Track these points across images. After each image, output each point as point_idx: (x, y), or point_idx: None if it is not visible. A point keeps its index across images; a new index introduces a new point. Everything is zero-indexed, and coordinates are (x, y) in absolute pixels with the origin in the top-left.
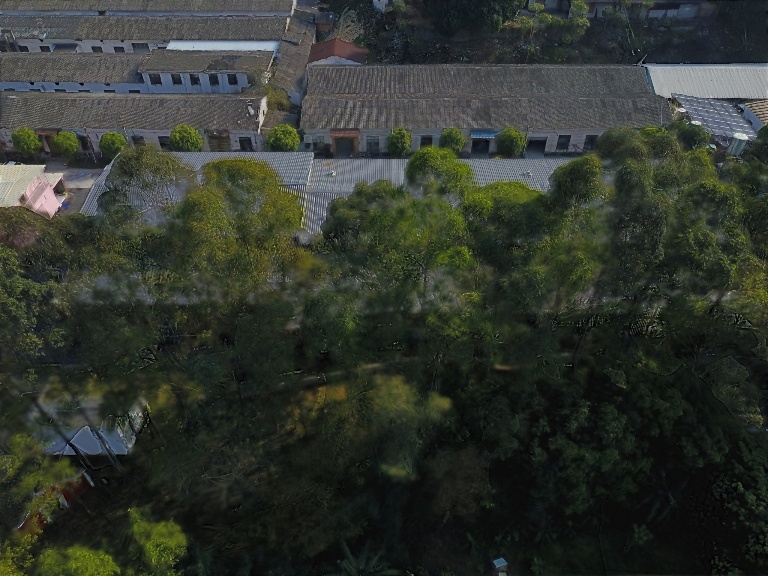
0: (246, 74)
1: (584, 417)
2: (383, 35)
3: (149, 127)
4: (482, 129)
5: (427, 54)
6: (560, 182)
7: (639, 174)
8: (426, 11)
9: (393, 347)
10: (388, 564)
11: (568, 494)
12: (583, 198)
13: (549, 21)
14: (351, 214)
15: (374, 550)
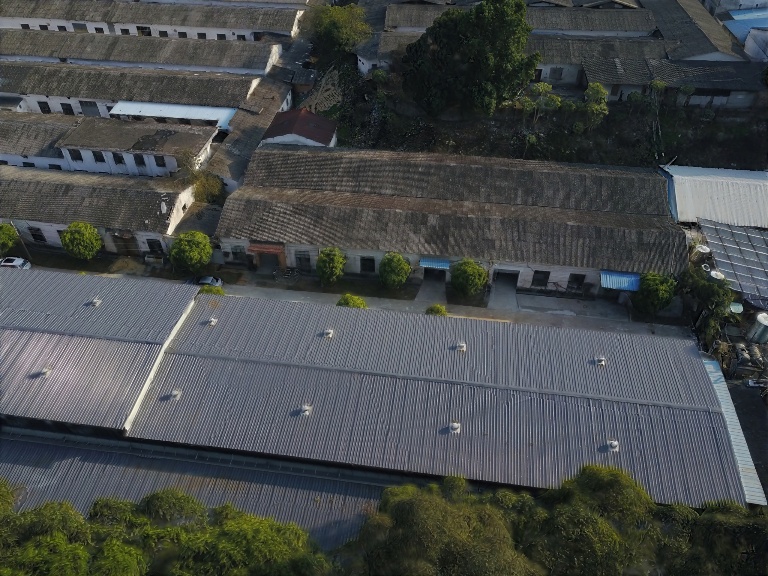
0: (174, 157)
1: None
2: (360, 106)
3: (45, 220)
4: (435, 256)
5: (407, 134)
6: None
7: None
8: (407, 85)
9: None
10: None
11: None
12: None
13: (557, 105)
14: None
15: None
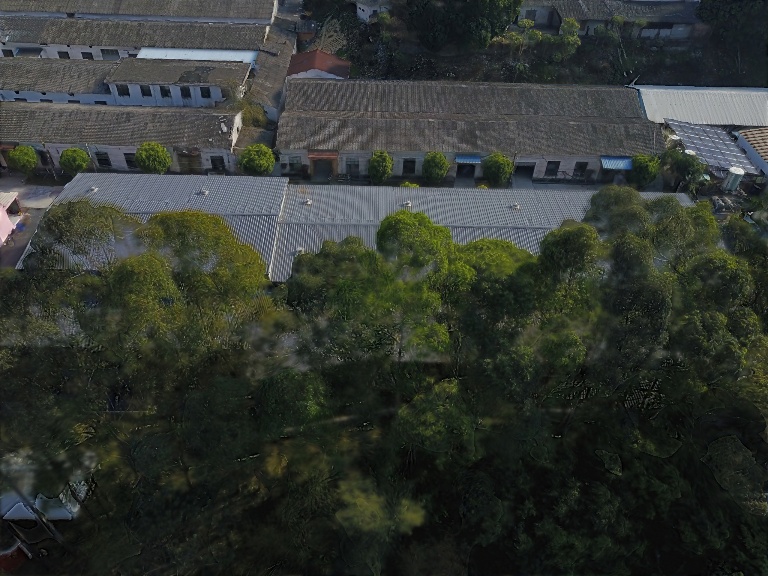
0: (220, 87)
1: (574, 499)
2: (367, 47)
3: (114, 143)
4: (468, 153)
5: (412, 69)
6: (553, 252)
7: (643, 251)
8: (412, 24)
9: (363, 428)
10: None
11: None
12: (579, 272)
13: (539, 38)
14: (316, 282)
15: None
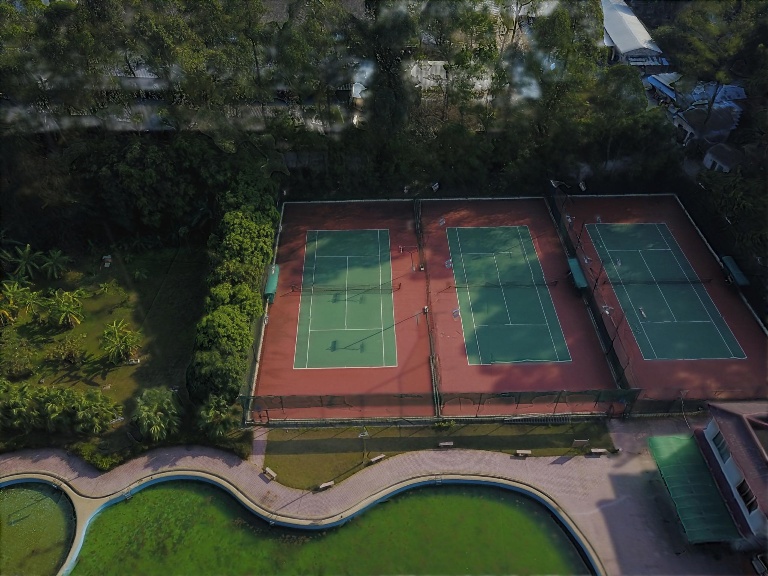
0: None
1: (137, 152)
2: None
3: None
4: None
5: None
6: None
7: None
8: None
9: (0, 96)
10: (14, 238)
11: (137, 205)
12: None
13: None
14: None
15: (1, 226)
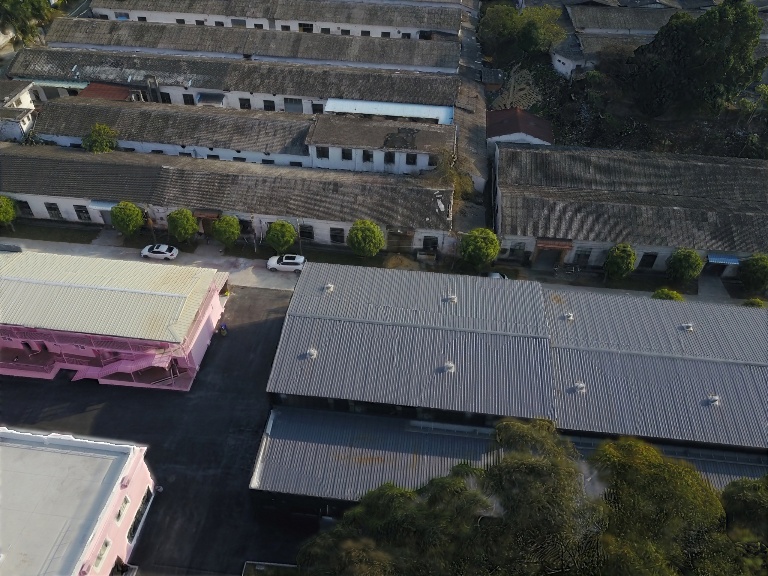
0: (429, 155)
1: None
2: (568, 106)
3: (323, 217)
4: (723, 252)
5: (622, 134)
6: None
7: None
8: (630, 86)
9: None
10: None
11: None
12: None
13: None
14: None
15: None
